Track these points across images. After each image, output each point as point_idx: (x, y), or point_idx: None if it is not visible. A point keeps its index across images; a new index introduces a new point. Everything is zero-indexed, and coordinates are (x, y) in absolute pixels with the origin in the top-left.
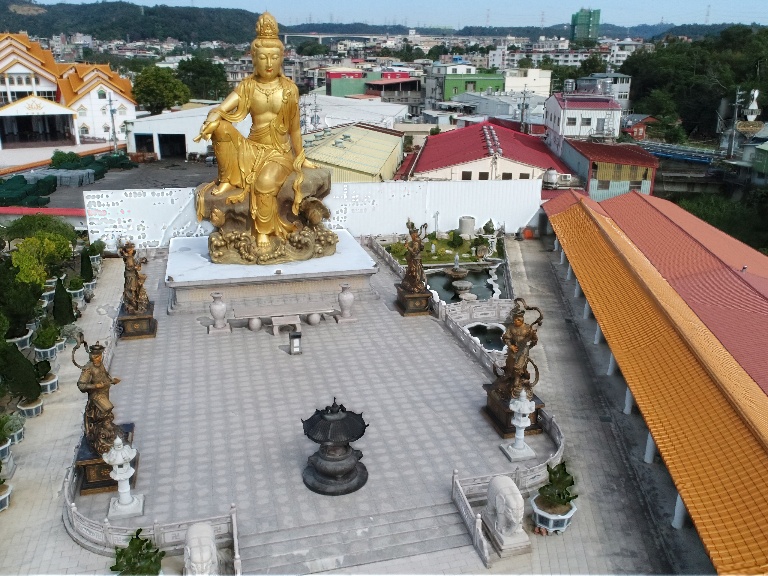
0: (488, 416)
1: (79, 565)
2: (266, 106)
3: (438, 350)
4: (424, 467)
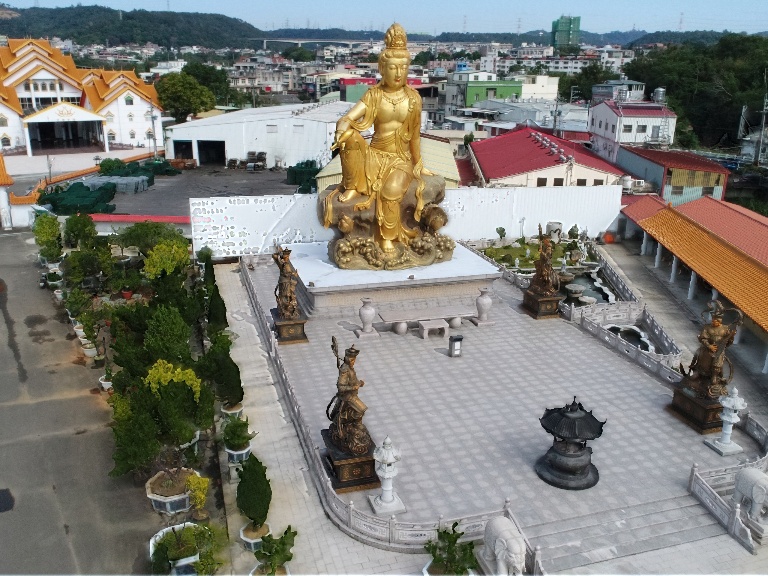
0: (677, 413)
1: (371, 560)
2: (392, 115)
3: (589, 351)
4: (644, 462)
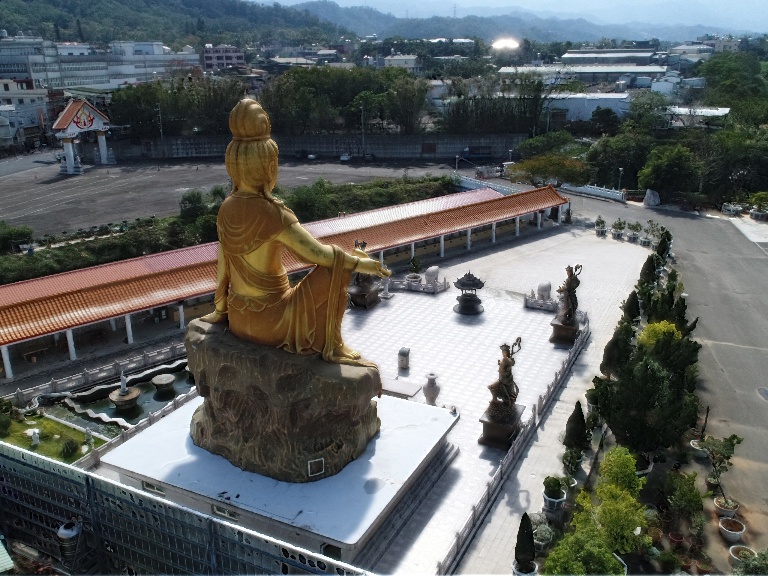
0: None
1: None
2: None
3: None
4: None
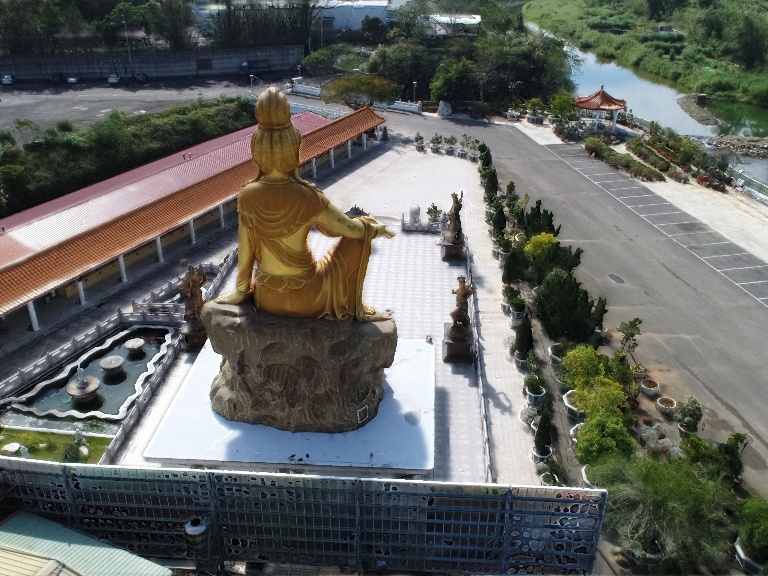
0: None
1: None
2: None
3: None
4: (317, 238)
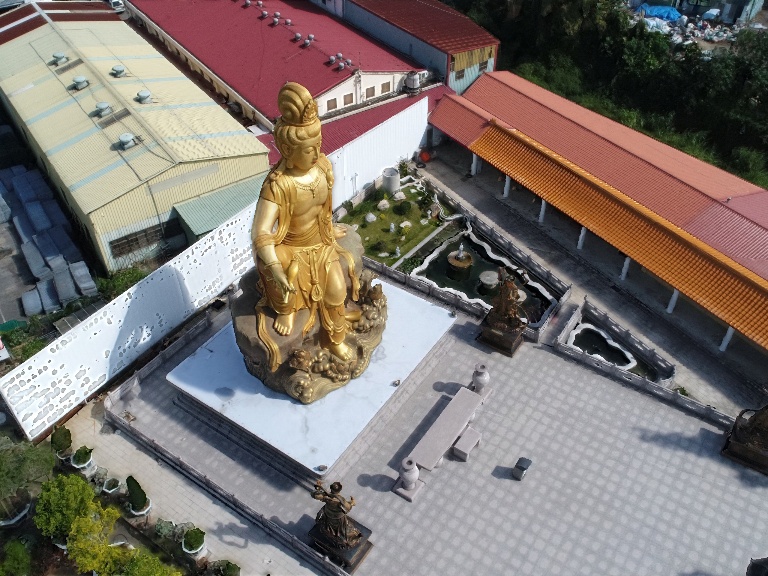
0: (739, 459)
1: None
2: (312, 203)
3: (598, 392)
4: None
